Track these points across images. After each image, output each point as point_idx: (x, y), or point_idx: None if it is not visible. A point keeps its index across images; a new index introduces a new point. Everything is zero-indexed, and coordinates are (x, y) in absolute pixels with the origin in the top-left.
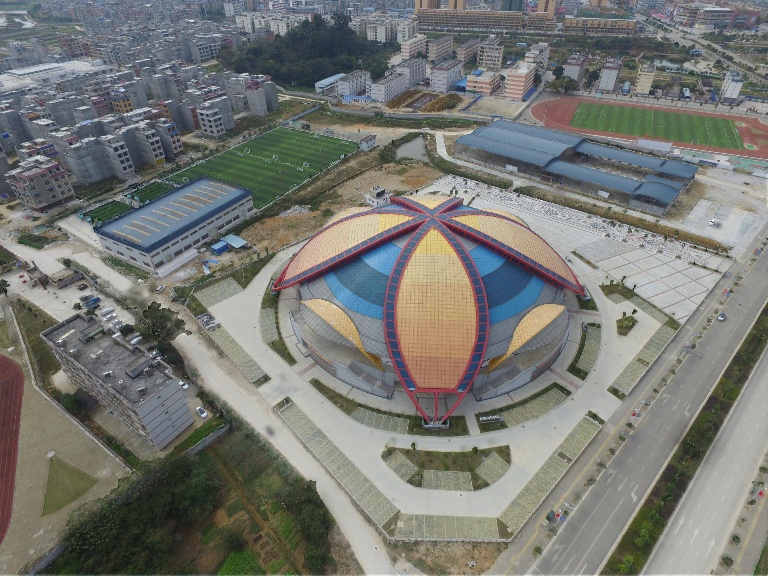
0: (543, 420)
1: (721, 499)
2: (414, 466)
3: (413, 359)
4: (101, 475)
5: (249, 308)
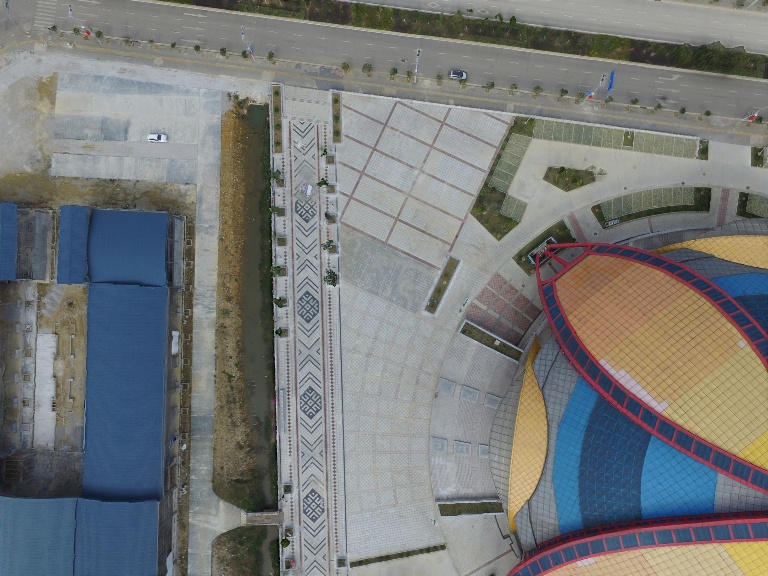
0: None
1: (765, 29)
2: None
3: None
4: None
5: None
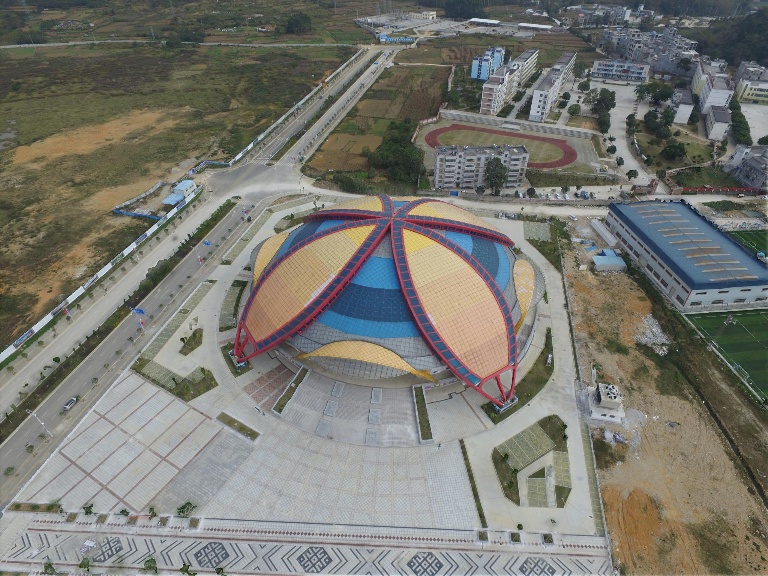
0: None
1: (157, 256)
2: None
3: None
4: None
5: None
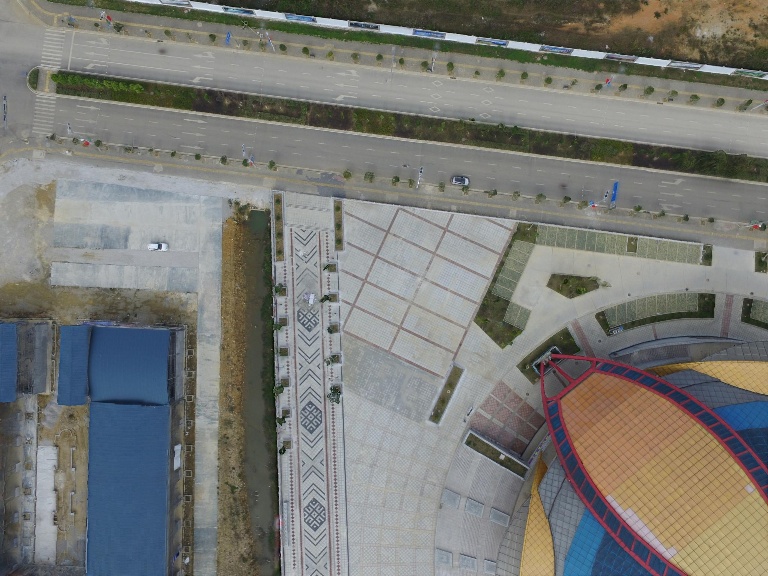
0: None
1: (767, 132)
2: None
3: None
4: None
5: None
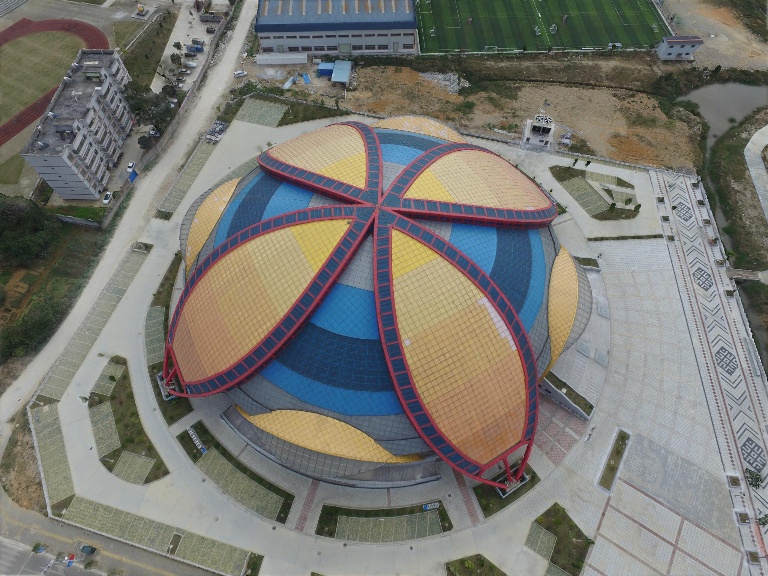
0: (223, 500)
1: None
2: (111, 390)
3: (184, 320)
4: (22, 181)
5: (252, 147)
